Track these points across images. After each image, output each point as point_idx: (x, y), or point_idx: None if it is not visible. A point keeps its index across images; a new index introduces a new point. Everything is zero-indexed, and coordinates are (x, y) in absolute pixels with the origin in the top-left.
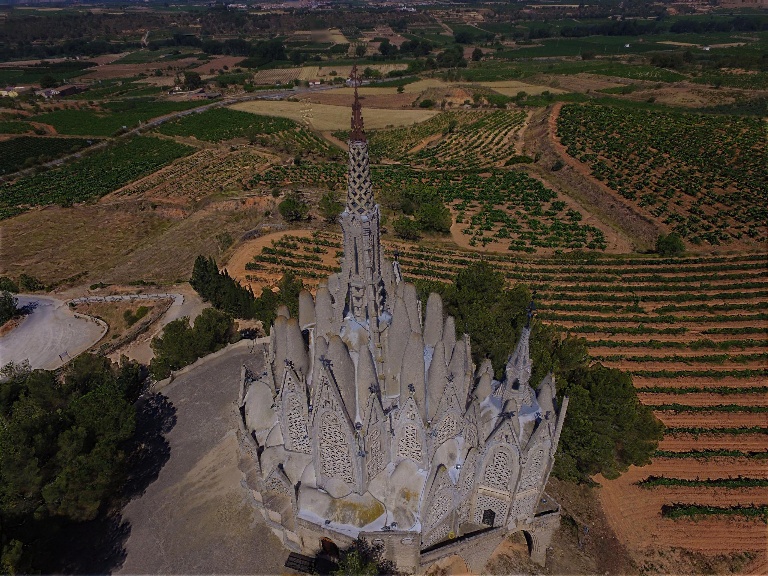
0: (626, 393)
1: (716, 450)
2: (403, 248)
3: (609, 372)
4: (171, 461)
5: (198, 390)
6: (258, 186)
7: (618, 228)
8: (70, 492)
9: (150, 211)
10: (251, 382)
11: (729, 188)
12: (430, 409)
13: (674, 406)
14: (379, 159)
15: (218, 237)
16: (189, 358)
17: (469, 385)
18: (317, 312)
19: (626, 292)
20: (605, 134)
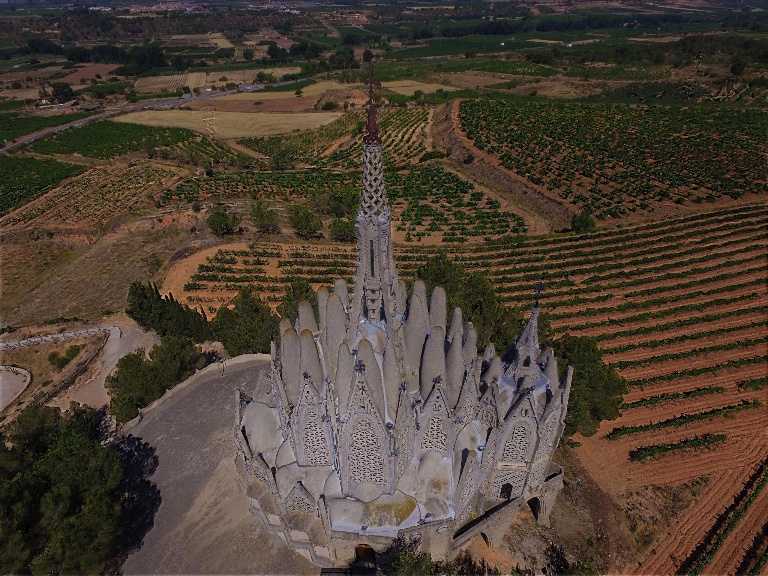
0: (596, 357)
1: (659, 396)
2: (345, 251)
3: (579, 340)
4: (164, 504)
5: (174, 424)
6: (171, 202)
7: (534, 212)
8: (69, 560)
9: (46, 240)
10: (246, 404)
11: (617, 168)
12: (451, 398)
13: (620, 363)
14: (293, 164)
15: (144, 260)
16: (154, 392)
17: (480, 370)
18: (329, 320)
19: (556, 269)
20: (505, 126)
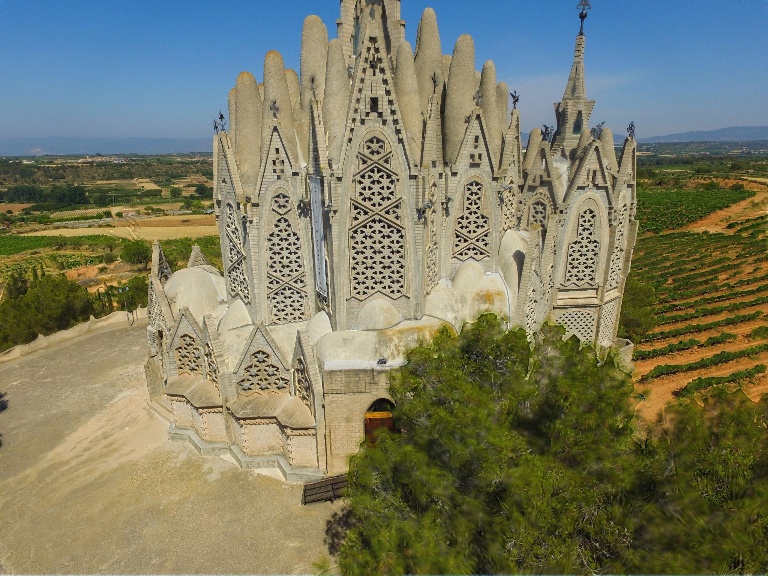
0: None
1: None
2: None
3: None
4: (5, 447)
5: (45, 368)
6: None
7: None
8: None
9: None
10: (168, 274)
11: None
12: None
13: None
14: None
15: None
16: (18, 344)
17: None
18: (306, 57)
19: None
20: None
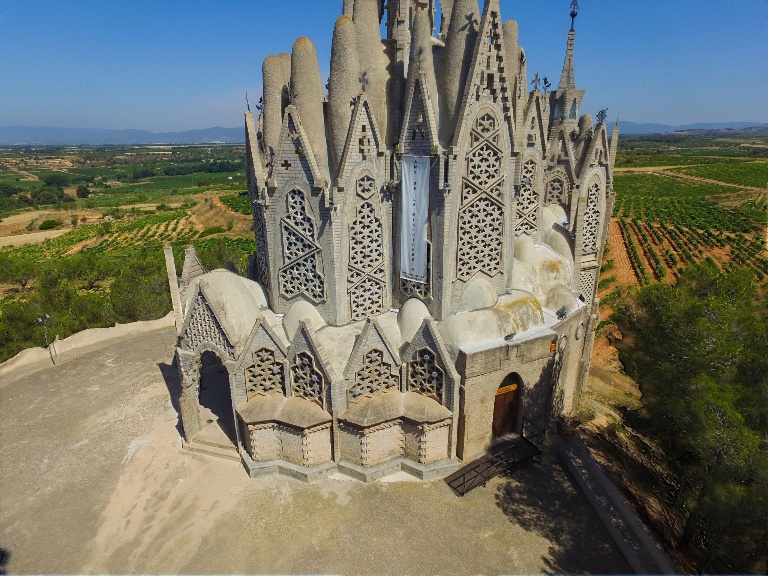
0: None
1: None
2: None
3: None
4: (15, 553)
5: None
6: None
7: None
8: None
9: None
10: (184, 284)
11: None
12: None
13: None
14: None
15: None
16: None
17: None
18: (361, 27)
19: None
20: None
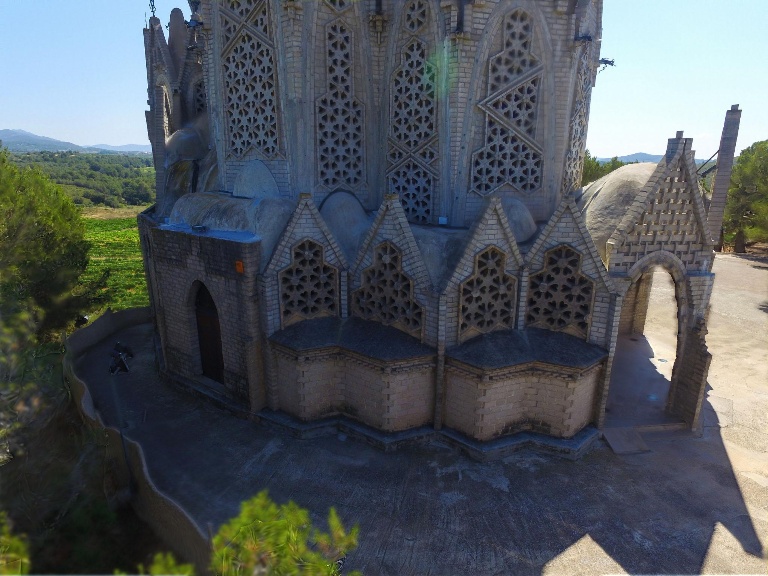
0: None
1: None
2: None
3: None
4: None
5: None
6: None
7: None
8: None
9: None
10: (702, 177)
11: None
12: None
13: None
14: None
15: None
16: None
17: None
18: None
19: None
20: None
